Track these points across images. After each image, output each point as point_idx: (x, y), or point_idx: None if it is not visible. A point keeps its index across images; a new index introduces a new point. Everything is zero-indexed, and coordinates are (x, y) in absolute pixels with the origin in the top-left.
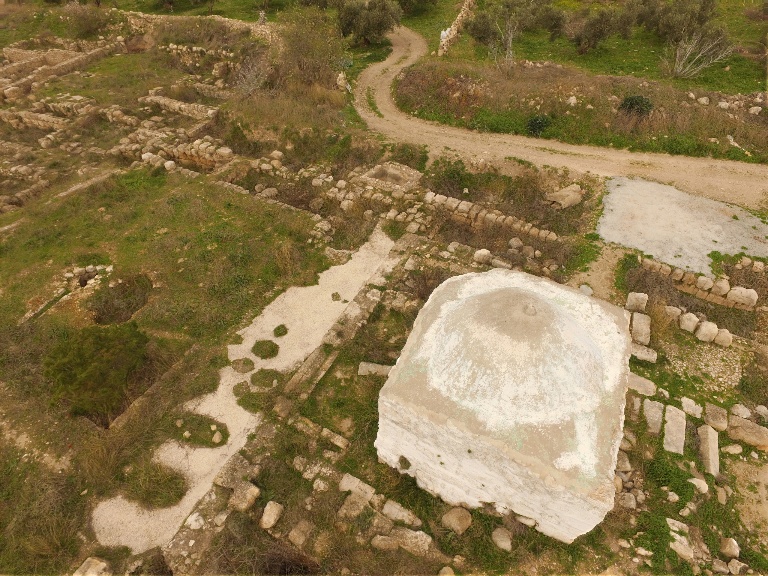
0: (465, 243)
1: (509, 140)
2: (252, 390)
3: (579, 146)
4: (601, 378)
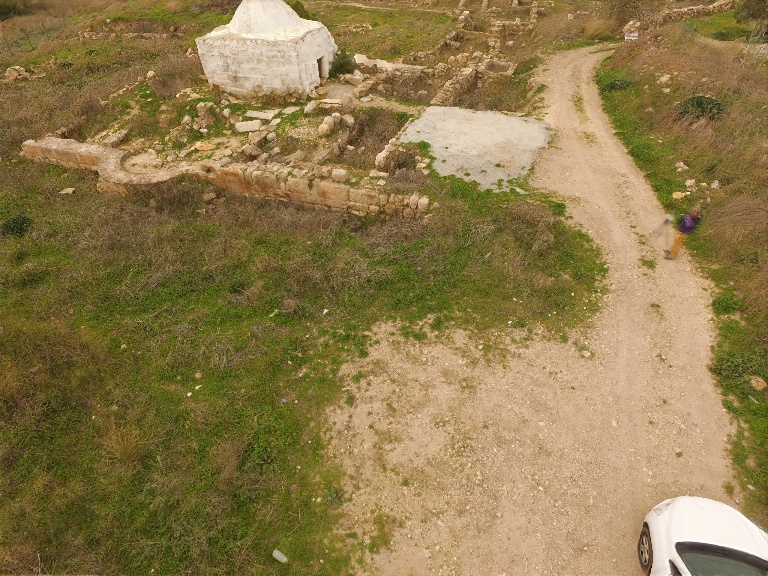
0: None
1: (587, 88)
2: None
3: (603, 112)
4: (246, 32)
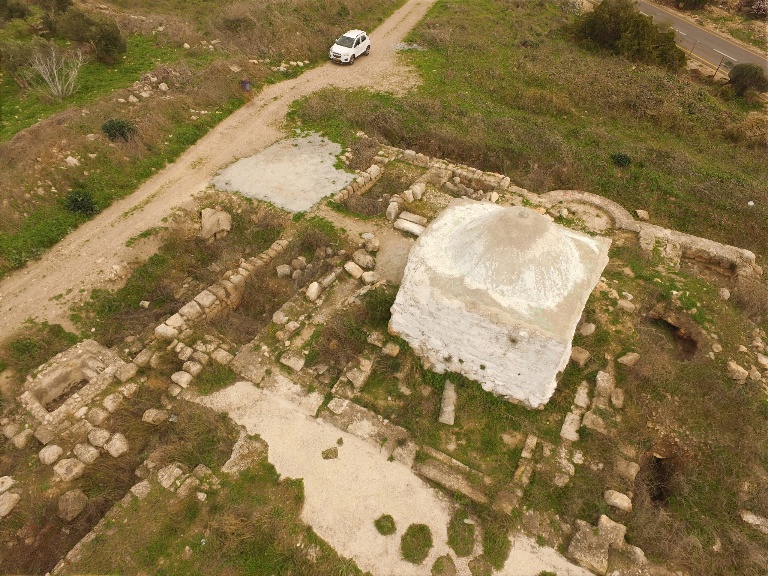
0: (251, 318)
1: (83, 237)
2: (480, 552)
3: (139, 189)
4: None
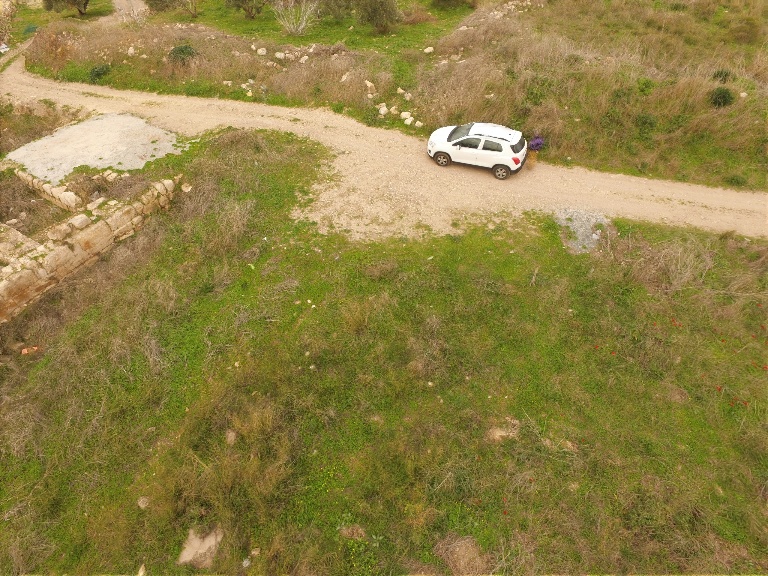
0: None
1: (72, 87)
2: None
3: (122, 91)
4: None
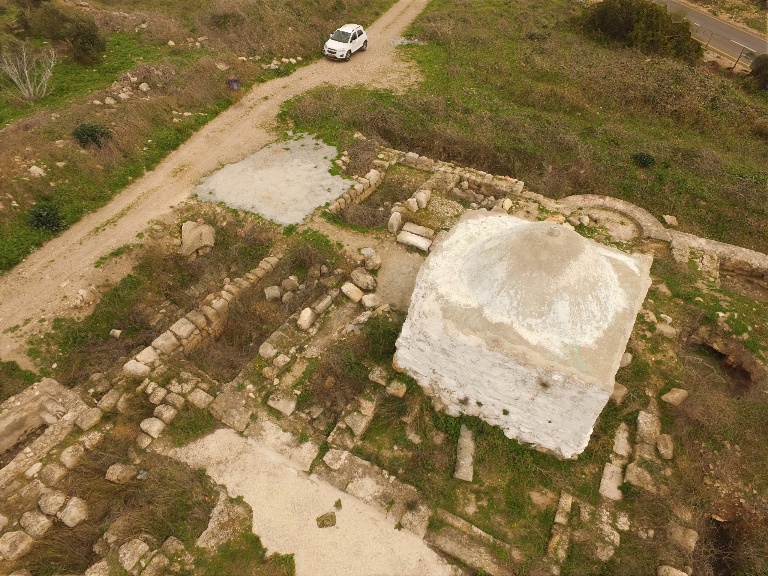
0: (236, 348)
1: (47, 256)
2: None
3: (113, 201)
4: None
